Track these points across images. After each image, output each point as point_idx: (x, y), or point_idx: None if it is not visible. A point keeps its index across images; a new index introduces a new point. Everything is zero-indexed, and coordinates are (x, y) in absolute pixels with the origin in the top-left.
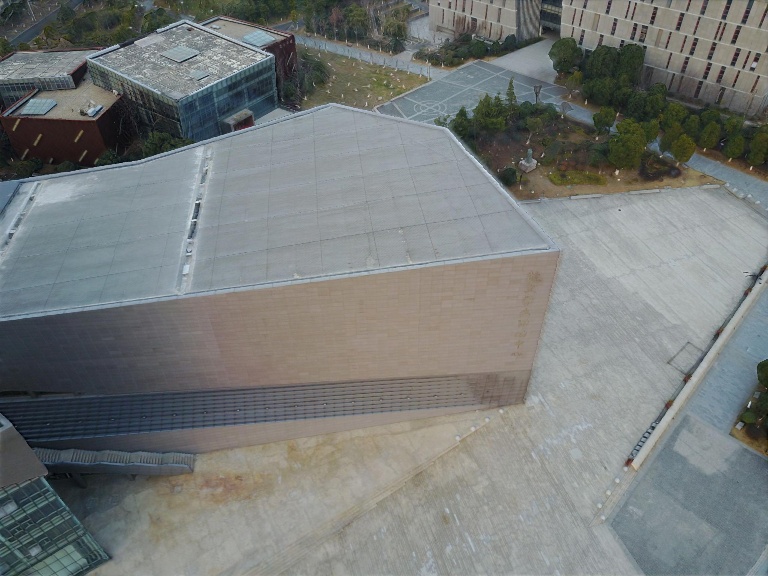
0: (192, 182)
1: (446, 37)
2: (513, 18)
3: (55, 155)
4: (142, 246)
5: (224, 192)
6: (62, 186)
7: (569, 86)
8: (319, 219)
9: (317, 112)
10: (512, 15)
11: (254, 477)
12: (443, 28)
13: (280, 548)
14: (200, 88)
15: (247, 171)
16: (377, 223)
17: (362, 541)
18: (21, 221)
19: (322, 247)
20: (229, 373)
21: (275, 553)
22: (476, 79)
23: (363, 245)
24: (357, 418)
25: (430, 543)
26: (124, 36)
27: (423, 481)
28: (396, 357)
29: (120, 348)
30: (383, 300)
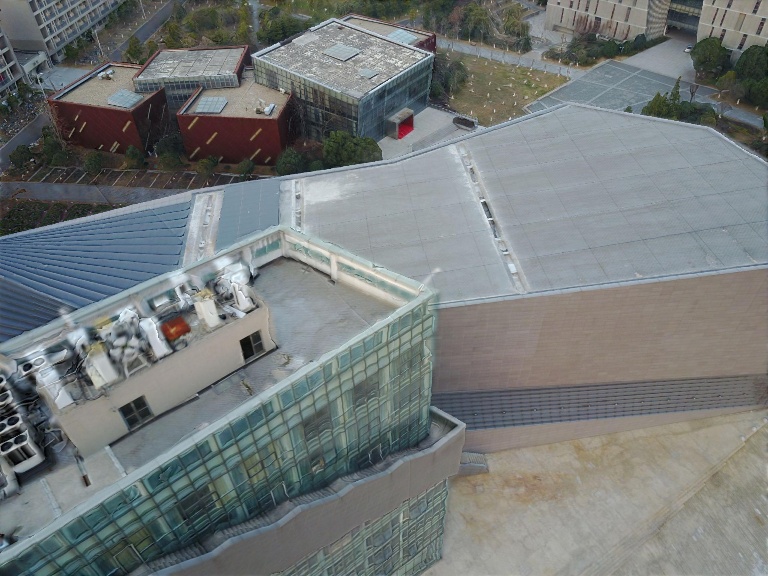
0: (464, 181)
1: (564, 36)
2: (644, 17)
3: (226, 153)
4: (450, 245)
5: (506, 191)
6: (324, 184)
7: (721, 86)
8: (627, 218)
9: (557, 111)
10: (643, 14)
11: (552, 477)
12: (560, 27)
13: (606, 548)
14: (374, 87)
15: (518, 170)
16: (694, 222)
17: (683, 542)
18: (302, 219)
19: (649, 246)
20: (532, 373)
21: (603, 553)
22: (615, 78)
23: (693, 244)
24: (643, 418)
25: (753, 544)
26: (247, 34)
27: (722, 482)
28: (699, 357)
29: (442, 347)
30: (718, 300)
